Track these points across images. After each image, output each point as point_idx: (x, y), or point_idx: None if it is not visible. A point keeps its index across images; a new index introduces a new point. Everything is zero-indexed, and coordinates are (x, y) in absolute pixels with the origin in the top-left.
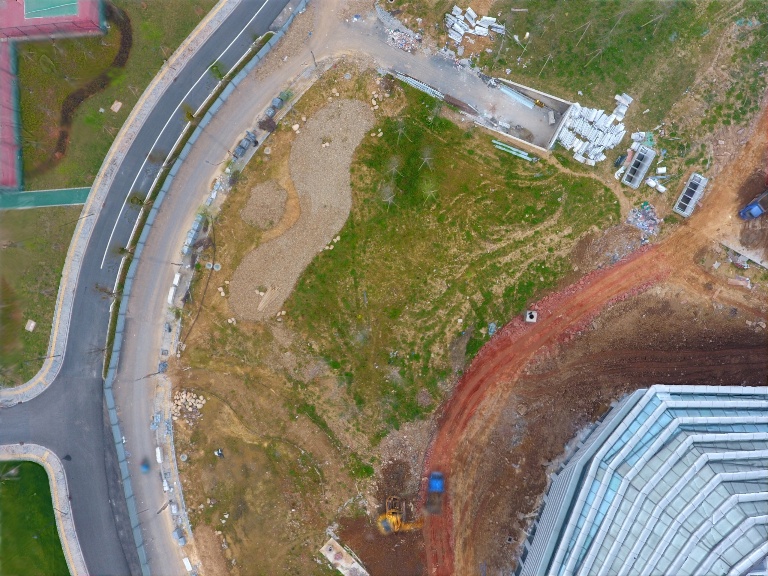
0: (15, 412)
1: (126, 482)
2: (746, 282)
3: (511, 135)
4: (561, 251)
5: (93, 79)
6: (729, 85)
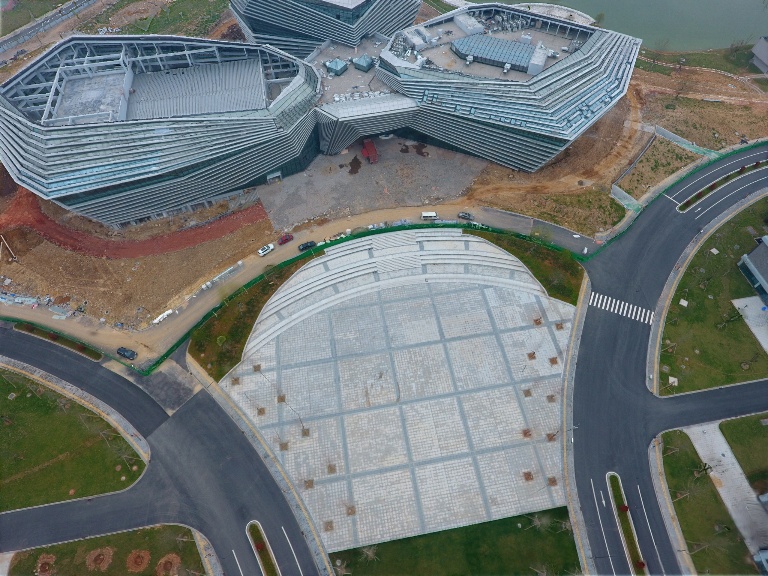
0: None
1: None
2: None
3: None
4: None
5: None
6: None
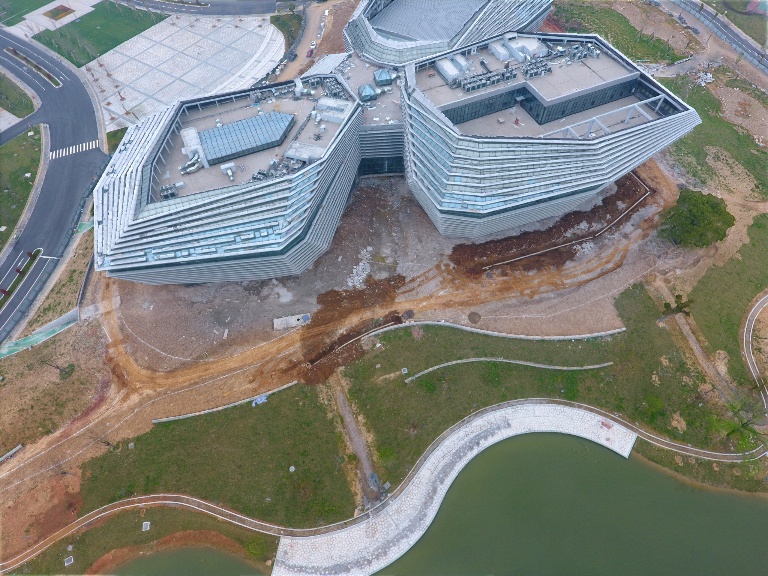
0: None
1: None
2: None
3: None
4: None
5: (728, 2)
6: None
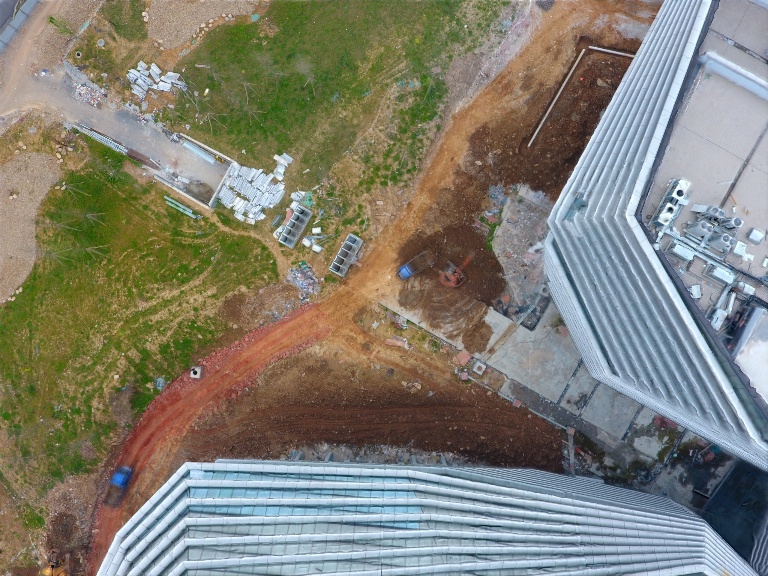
0: None
1: None
2: (403, 343)
3: None
4: (207, 311)
5: None
6: (386, 146)
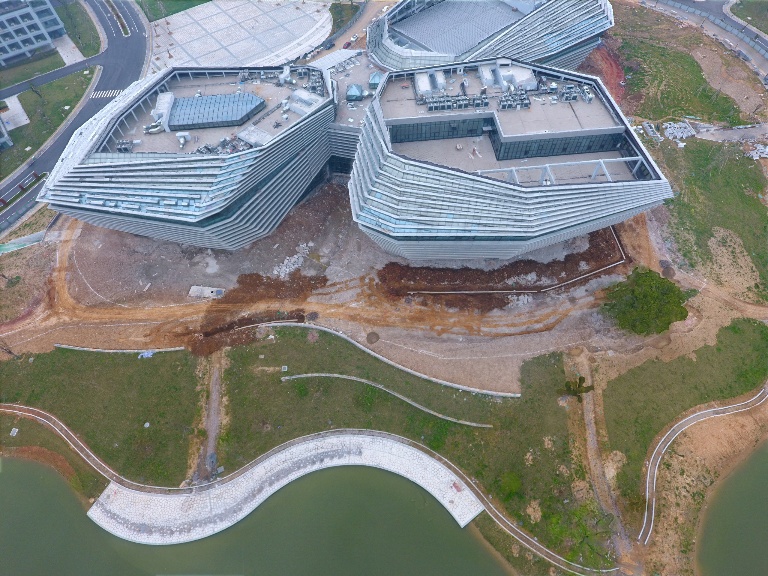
0: (722, 3)
1: (673, 3)
2: None
3: None
4: None
5: None
6: None
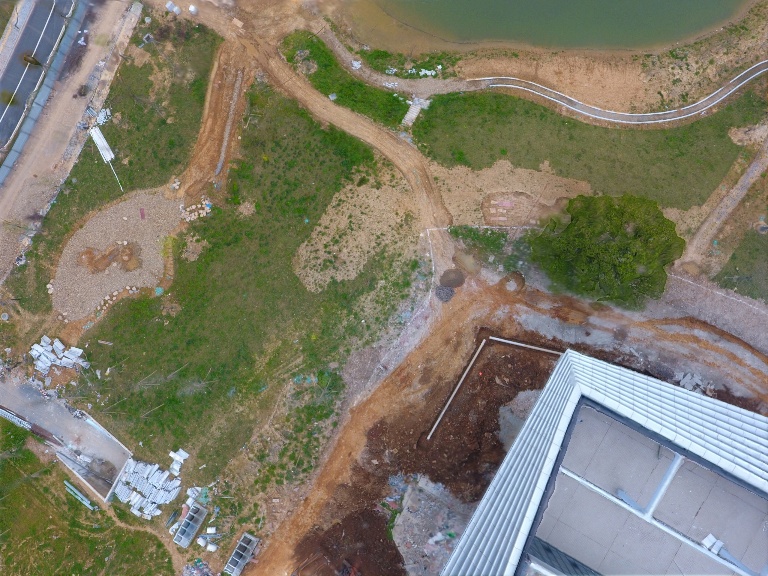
0: None
1: None
2: None
3: (84, 476)
4: None
5: None
6: (282, 445)
